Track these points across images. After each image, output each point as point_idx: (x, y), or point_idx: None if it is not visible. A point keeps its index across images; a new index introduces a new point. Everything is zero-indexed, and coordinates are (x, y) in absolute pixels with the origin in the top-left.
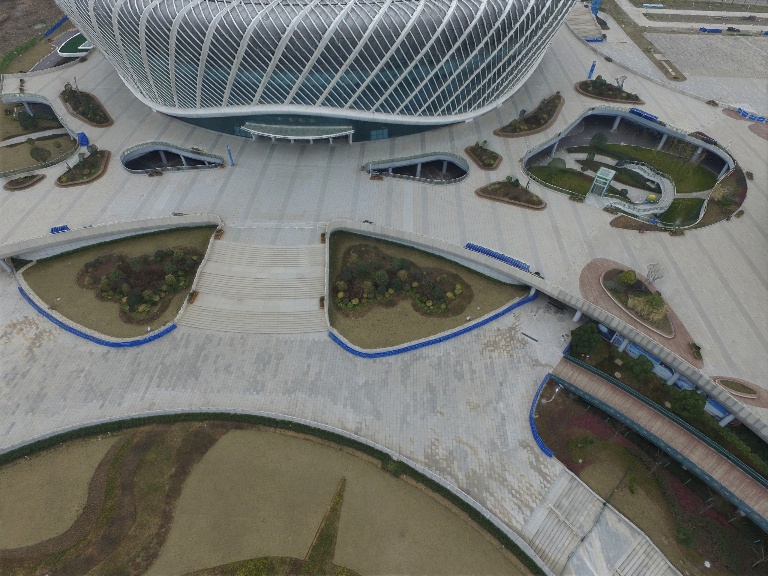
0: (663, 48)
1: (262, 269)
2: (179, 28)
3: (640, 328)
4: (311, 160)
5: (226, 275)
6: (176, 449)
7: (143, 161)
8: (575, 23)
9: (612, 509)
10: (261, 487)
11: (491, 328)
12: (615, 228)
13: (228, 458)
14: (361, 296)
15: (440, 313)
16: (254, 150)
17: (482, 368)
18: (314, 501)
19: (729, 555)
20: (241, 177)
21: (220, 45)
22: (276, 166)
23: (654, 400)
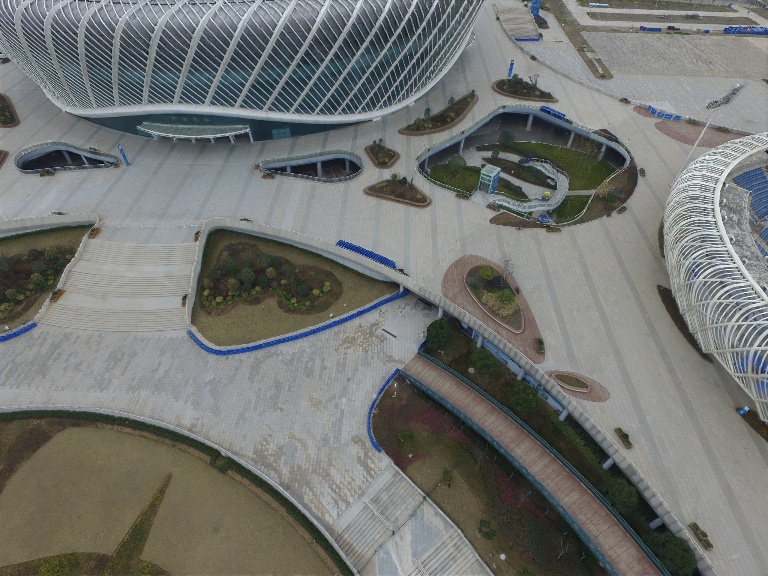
0: (597, 47)
1: (132, 267)
2: (52, 28)
3: (491, 323)
4: (208, 159)
5: (94, 274)
6: (8, 447)
7: (49, 161)
8: (513, 22)
9: (430, 503)
10: (84, 484)
11: (353, 325)
12: (493, 225)
13: (58, 455)
14: (226, 294)
15: (304, 310)
16: (153, 150)
17: (334, 364)
18: (134, 497)
19: (537, 547)
20: (133, 176)
21: (94, 45)
22: (171, 165)
23: (501, 395)
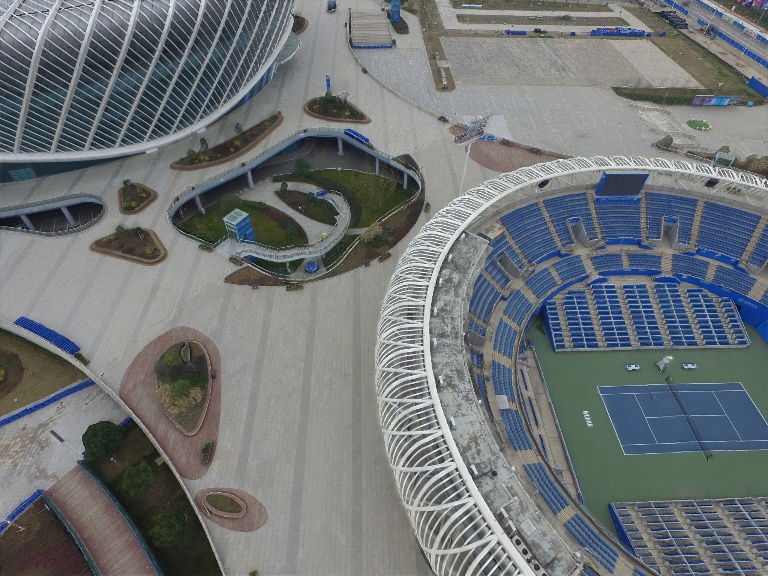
0: (451, 54)
1: None
2: None
3: (162, 424)
4: None
5: None
6: None
7: None
8: (367, 28)
9: None
10: None
11: (15, 427)
12: (227, 284)
13: None
14: None
15: None
16: None
17: None
18: None
19: None
20: None
21: None
22: None
23: None
